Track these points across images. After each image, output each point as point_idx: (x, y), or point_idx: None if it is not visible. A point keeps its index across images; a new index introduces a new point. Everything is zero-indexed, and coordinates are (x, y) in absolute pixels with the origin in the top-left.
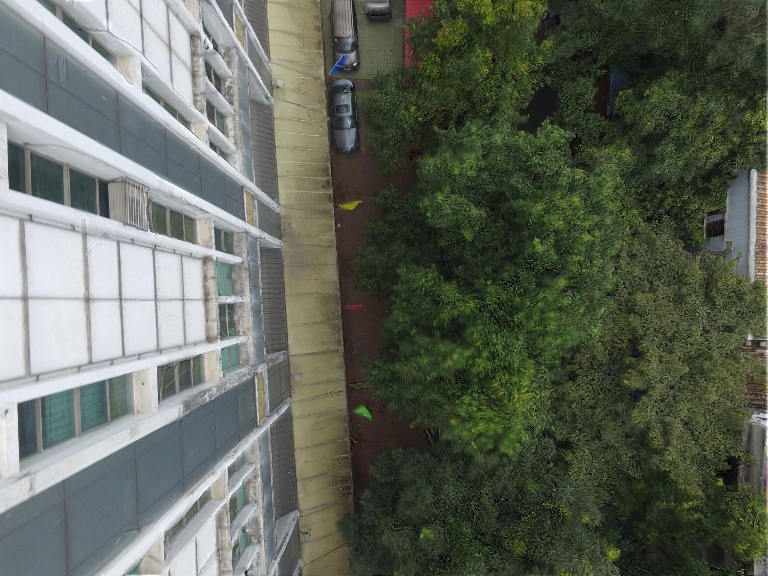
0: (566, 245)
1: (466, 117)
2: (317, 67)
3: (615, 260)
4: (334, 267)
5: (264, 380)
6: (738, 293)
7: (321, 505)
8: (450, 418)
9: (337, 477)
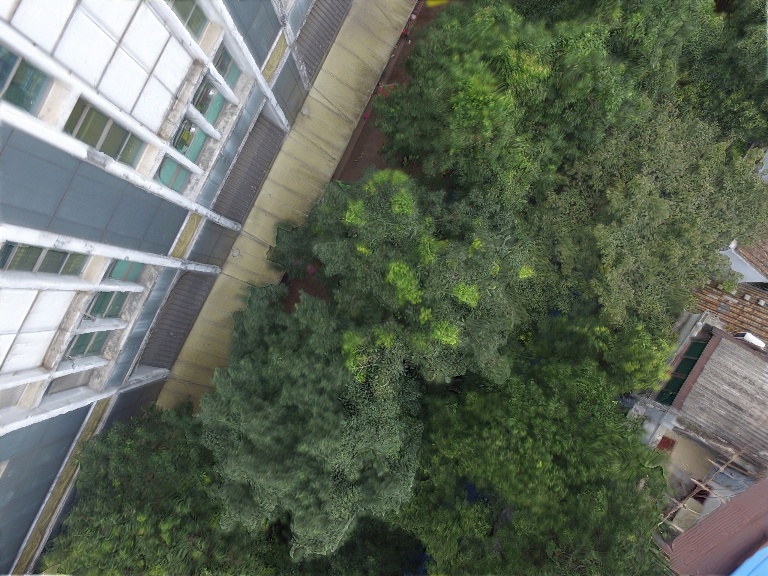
0: (633, 6)
1: None
2: None
3: None
4: (390, 49)
5: (284, 56)
6: (749, 182)
7: (263, 238)
8: (436, 138)
9: (289, 229)
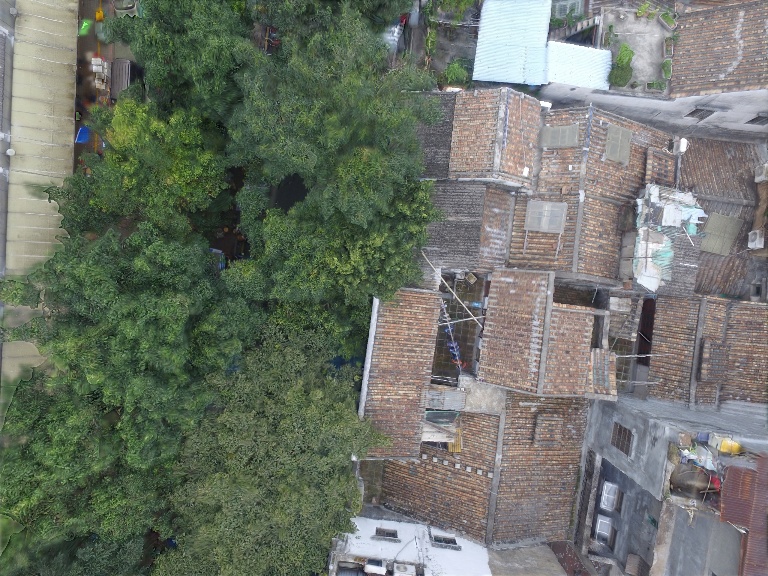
0: None
1: (140, 215)
2: (67, 134)
3: (245, 371)
4: None
5: None
6: None
7: None
8: None
9: None
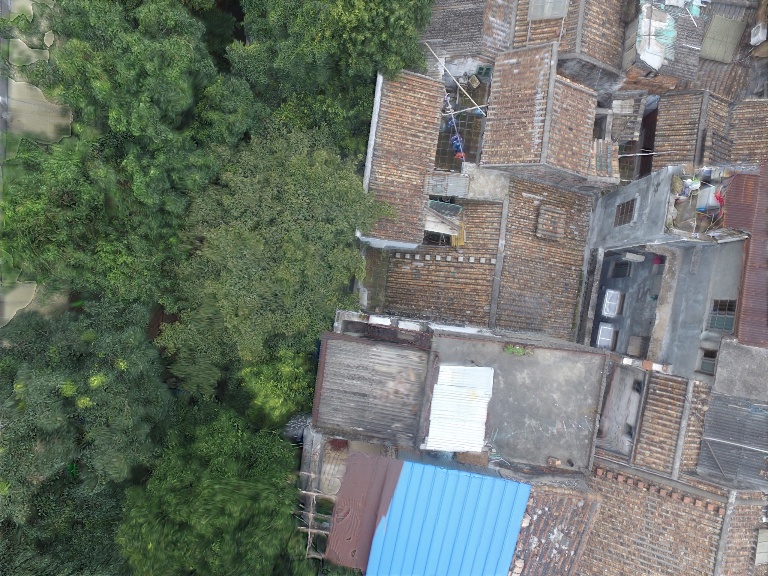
0: (104, 103)
1: None
2: None
3: None
4: None
5: None
6: None
7: None
8: None
9: None
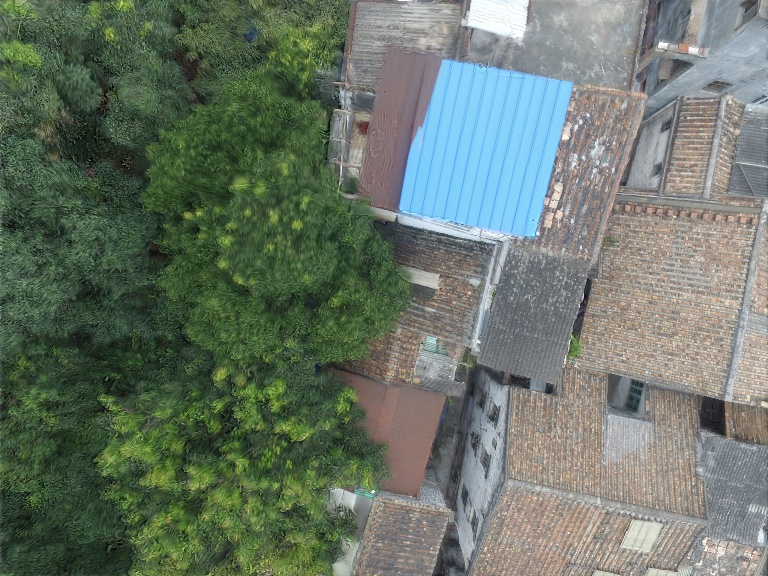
0: None
1: None
2: None
3: None
4: None
5: None
6: None
7: None
8: None
9: None
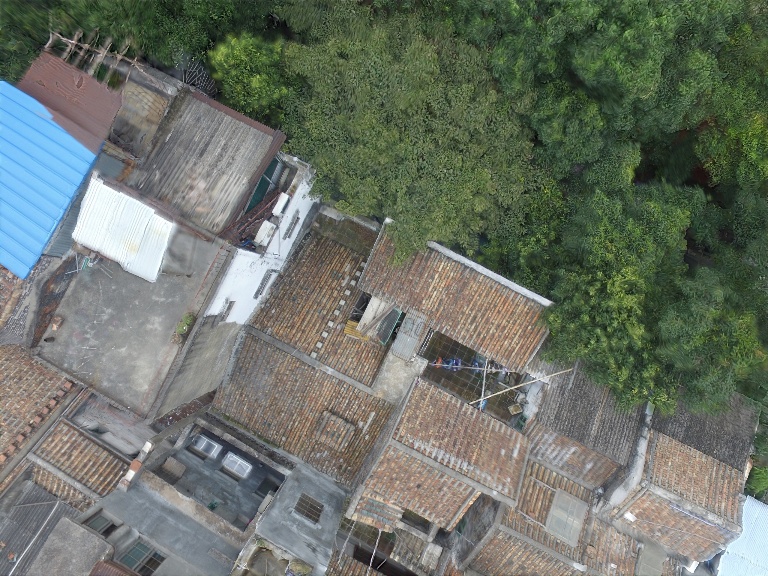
0: None
1: None
2: None
3: None
4: None
5: None
6: None
7: None
8: None
9: None
